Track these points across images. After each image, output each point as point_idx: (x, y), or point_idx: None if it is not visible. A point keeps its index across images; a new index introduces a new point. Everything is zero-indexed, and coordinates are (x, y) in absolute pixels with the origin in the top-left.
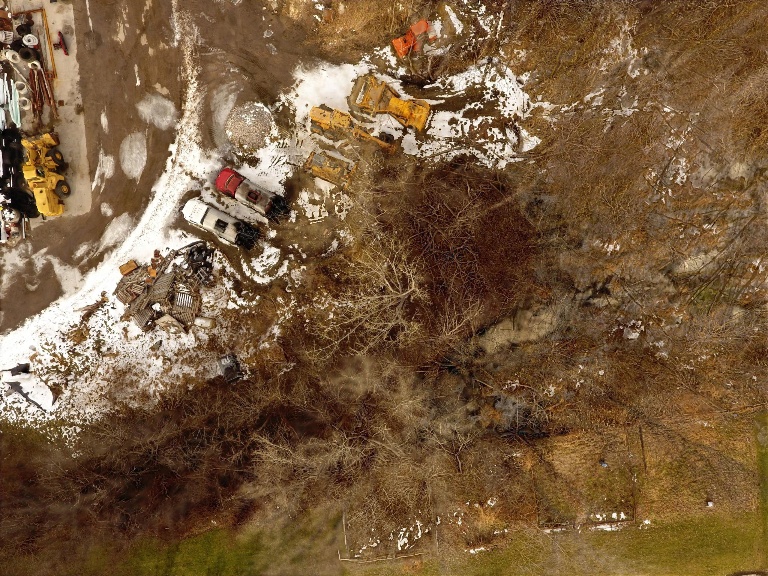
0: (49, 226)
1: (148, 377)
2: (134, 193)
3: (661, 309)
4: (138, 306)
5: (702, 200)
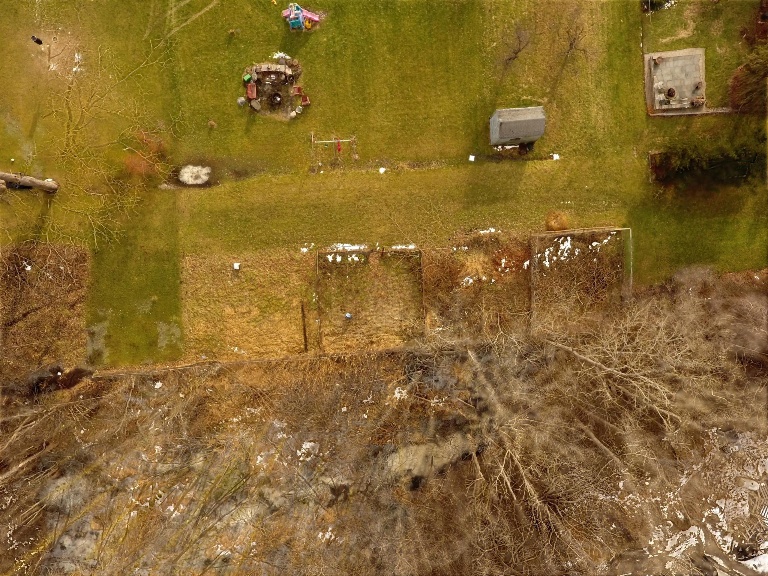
0: None
1: None
2: None
3: (279, 471)
4: None
5: None
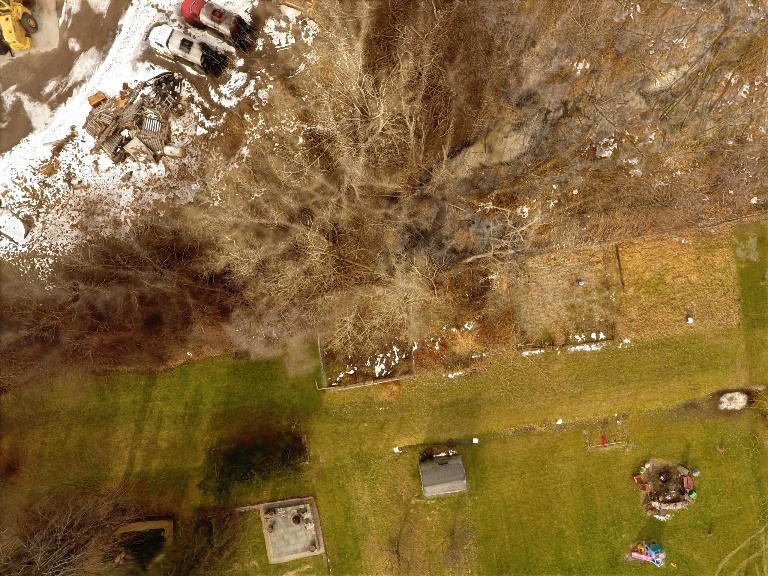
0: (18, 63)
1: (119, 206)
2: (101, 27)
3: (633, 126)
4: (107, 133)
5: (670, 12)
